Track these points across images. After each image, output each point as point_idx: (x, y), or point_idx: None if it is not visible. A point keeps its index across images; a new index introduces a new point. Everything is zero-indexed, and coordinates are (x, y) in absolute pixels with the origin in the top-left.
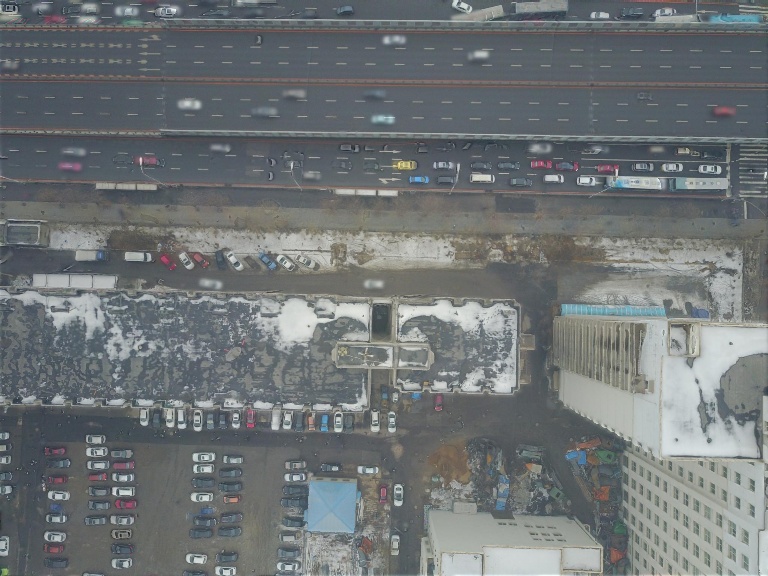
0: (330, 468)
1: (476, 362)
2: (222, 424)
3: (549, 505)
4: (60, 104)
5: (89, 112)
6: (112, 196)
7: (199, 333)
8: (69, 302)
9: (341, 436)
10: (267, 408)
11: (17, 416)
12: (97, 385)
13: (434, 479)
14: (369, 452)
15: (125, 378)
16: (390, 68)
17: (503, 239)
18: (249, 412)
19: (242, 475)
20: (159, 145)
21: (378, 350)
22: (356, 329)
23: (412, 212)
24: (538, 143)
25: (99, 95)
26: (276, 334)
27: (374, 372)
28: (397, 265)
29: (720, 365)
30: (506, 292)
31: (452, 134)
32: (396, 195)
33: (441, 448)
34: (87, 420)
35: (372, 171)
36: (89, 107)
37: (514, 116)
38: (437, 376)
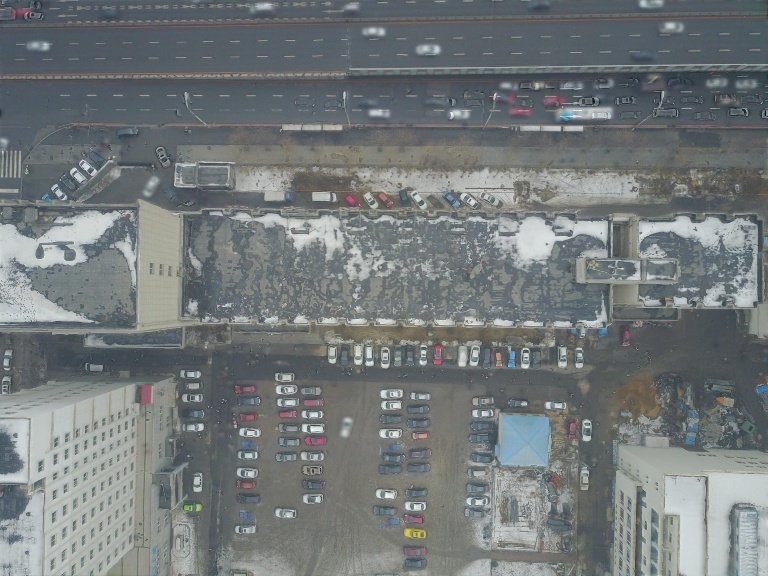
0: (519, 403)
1: (716, 278)
2: (410, 361)
3: (740, 439)
4: (245, 48)
5: (273, 55)
6: (298, 137)
7: (437, 252)
8: (309, 224)
9: (527, 372)
10: (508, 325)
11: (207, 355)
12: (337, 305)
13: (624, 414)
14: (555, 388)
15: (365, 298)
16: (576, 3)
17: (687, 174)
18: (437, 349)
19: (429, 412)
20: (340, 87)
21: (625, 264)
22: (594, 246)
23: None
24: (721, 77)
25: (283, 38)
26: (514, 252)
27: None
28: (581, 201)
29: None
30: None
31: (645, 66)
32: (581, 131)
33: (628, 383)
34: (275, 359)
35: (553, 108)
36: (273, 50)
37: (704, 47)
38: (677, 292)
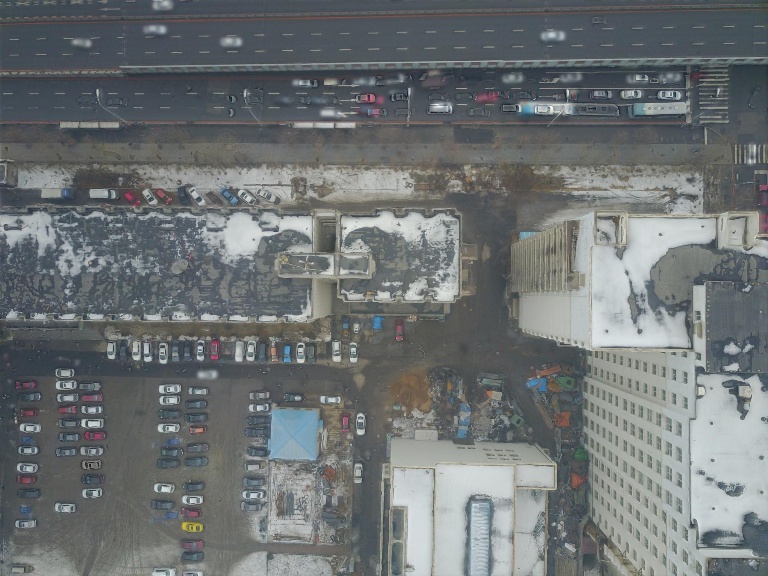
0: (293, 398)
1: (419, 272)
2: (187, 356)
3: (510, 432)
4: (24, 46)
5: (52, 53)
6: (76, 135)
7: (147, 248)
8: (21, 220)
9: (304, 367)
10: (214, 320)
11: None
12: (50, 300)
13: (395, 407)
14: (332, 382)
15: (76, 293)
16: (345, 0)
17: (462, 170)
18: (213, 344)
19: (207, 406)
20: (122, 85)
21: (319, 259)
22: (300, 241)
23: (371, 145)
24: (496, 73)
25: (61, 36)
26: (222, 248)
27: (334, 302)
28: (357, 198)
29: (650, 256)
30: (465, 222)
31: (406, 62)
32: (354, 127)
33: (402, 377)
34: (56, 355)
35: (331, 105)
36: (52, 48)
37: (469, 44)
38: (381, 286)
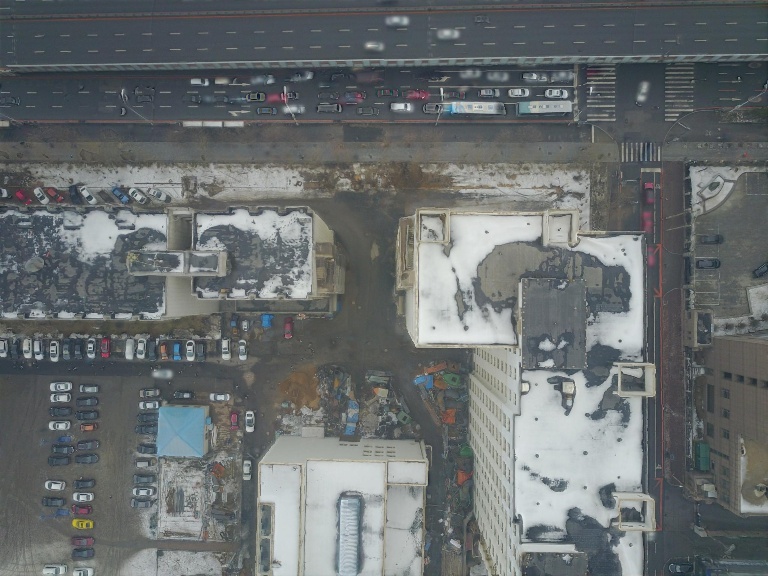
0: (182, 395)
1: (273, 270)
2: (77, 354)
3: (398, 429)
4: None
5: None
6: None
7: (5, 246)
8: None
9: (194, 365)
10: (69, 317)
11: None
12: None
13: (283, 405)
14: (222, 380)
15: None
16: None
17: (351, 168)
18: (103, 342)
19: (99, 404)
20: (14, 84)
21: (170, 256)
22: (156, 239)
23: (261, 143)
24: (385, 72)
25: None
26: (79, 246)
27: (222, 300)
28: (247, 196)
29: (477, 254)
30: (354, 220)
31: (289, 61)
32: (242, 126)
33: (292, 375)
34: None
35: (222, 104)
36: None
37: (353, 43)
38: (236, 284)
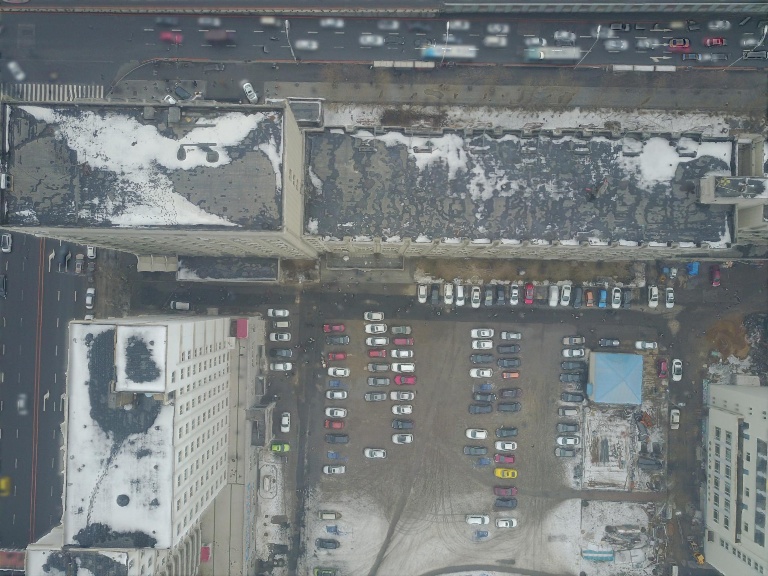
0: (610, 343)
1: None
2: (500, 300)
3: None
4: None
5: None
6: (389, 74)
7: (561, 173)
8: (431, 143)
9: (617, 312)
10: (633, 245)
11: (294, 294)
12: (460, 225)
13: (715, 353)
14: (645, 328)
15: (488, 218)
16: None
17: None
18: (528, 288)
19: (519, 352)
20: (430, 25)
21: (754, 182)
22: (718, 168)
23: (685, 90)
24: None
25: None
26: (638, 173)
27: None
28: None
29: None
30: None
31: (741, 4)
32: (674, 70)
33: (718, 323)
34: (364, 298)
35: (643, 50)
36: None
37: None
38: None
